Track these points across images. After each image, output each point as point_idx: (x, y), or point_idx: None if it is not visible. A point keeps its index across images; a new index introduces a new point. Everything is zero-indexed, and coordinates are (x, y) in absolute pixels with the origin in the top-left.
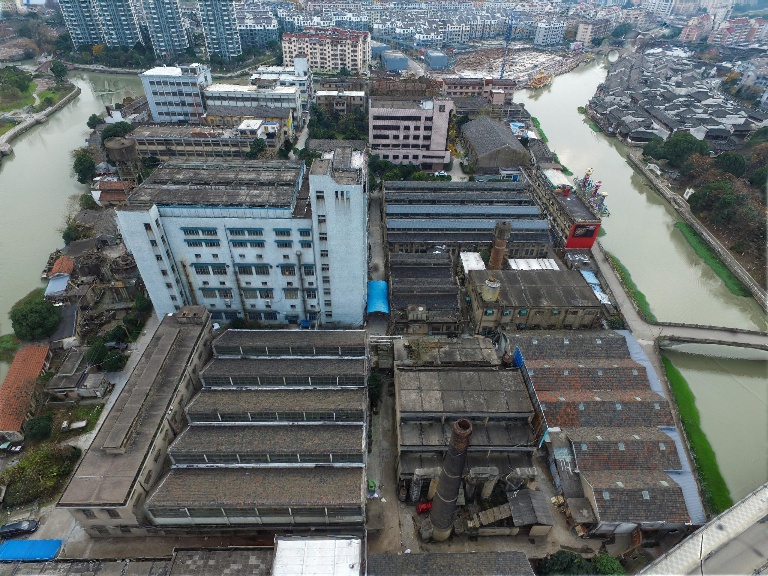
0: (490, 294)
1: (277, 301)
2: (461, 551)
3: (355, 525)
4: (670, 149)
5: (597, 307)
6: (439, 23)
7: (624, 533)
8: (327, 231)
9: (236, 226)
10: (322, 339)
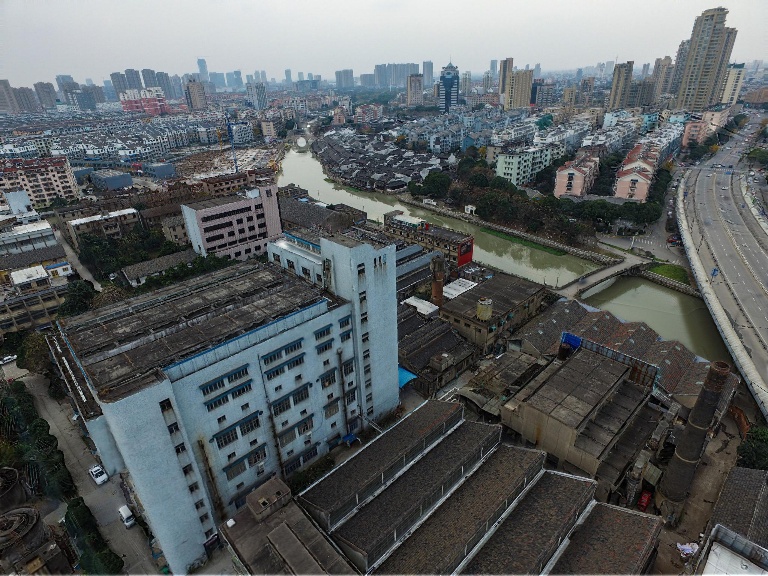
0: (489, 312)
1: (317, 429)
2: (695, 510)
3: (653, 555)
4: (431, 185)
5: (543, 289)
6: (133, 139)
7: (724, 415)
8: (367, 309)
9: (271, 349)
10: (418, 428)
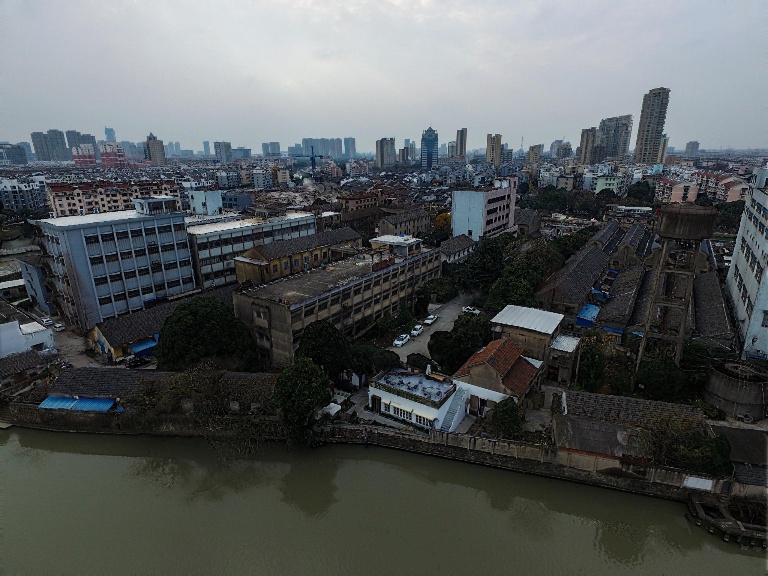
0: None
1: None
2: None
3: None
4: (555, 202)
5: None
6: (176, 175)
7: None
8: None
9: None
10: None
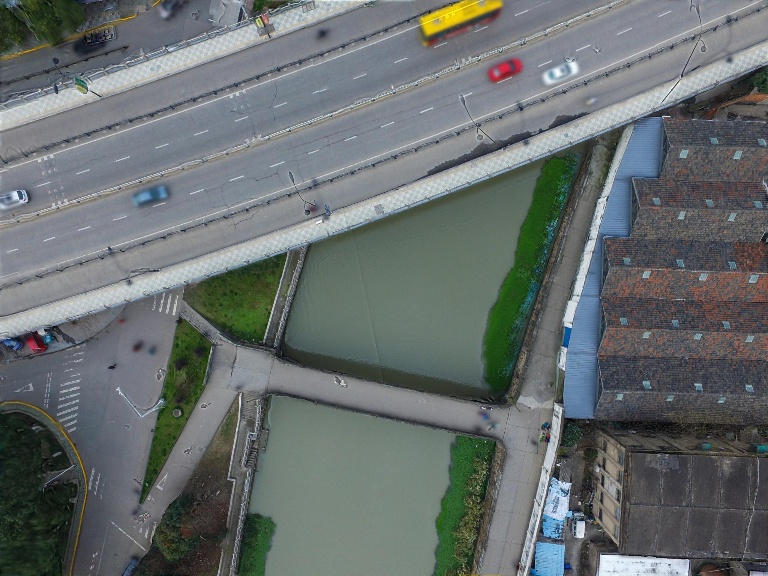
0: None
1: None
2: None
3: None
4: None
5: (639, 451)
6: None
7: None
8: None
9: None
10: None
